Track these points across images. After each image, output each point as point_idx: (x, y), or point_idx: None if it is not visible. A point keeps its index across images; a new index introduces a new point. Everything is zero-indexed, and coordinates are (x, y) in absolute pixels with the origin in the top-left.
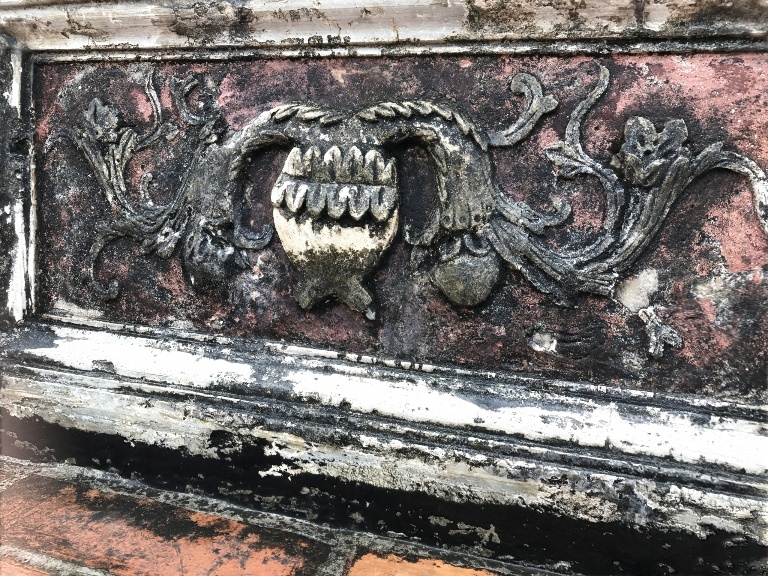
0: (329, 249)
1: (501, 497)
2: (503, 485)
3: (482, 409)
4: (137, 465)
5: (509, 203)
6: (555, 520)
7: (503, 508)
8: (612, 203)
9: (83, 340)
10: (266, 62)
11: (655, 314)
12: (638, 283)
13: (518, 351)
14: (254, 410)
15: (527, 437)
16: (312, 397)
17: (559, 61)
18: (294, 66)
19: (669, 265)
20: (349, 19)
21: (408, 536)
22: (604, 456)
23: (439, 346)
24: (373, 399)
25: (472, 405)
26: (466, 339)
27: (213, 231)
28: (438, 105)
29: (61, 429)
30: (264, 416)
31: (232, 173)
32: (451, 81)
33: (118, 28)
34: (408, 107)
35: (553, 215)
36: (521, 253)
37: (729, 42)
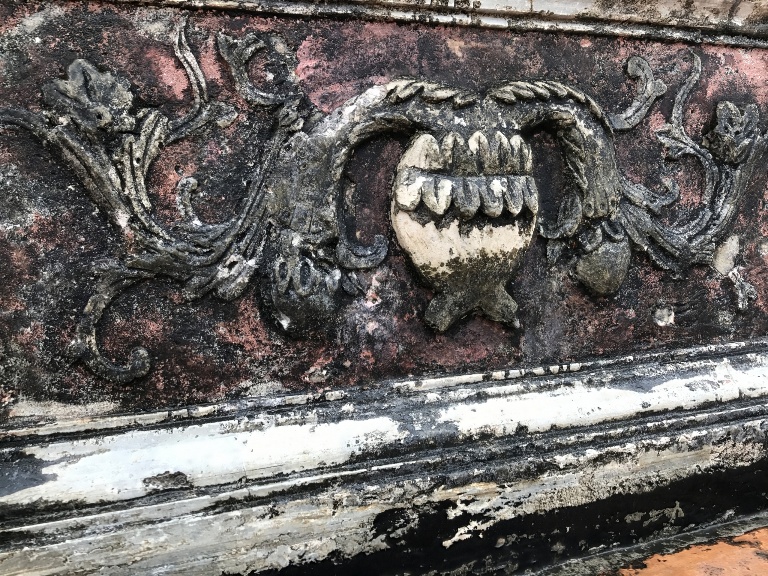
0: (479, 254)
1: (683, 472)
2: (684, 459)
3: (641, 393)
4: None
5: (631, 186)
6: (722, 476)
7: (685, 481)
8: (710, 180)
9: (101, 454)
10: (364, 24)
11: (739, 274)
12: (726, 249)
13: (647, 330)
14: (424, 470)
15: (685, 408)
16: (484, 432)
17: (662, 47)
18: (401, 32)
19: (745, 230)
20: None
21: (608, 545)
22: (743, 405)
23: (580, 341)
24: (547, 414)
25: (631, 392)
26: (603, 328)
27: (312, 251)
28: (568, 86)
29: None
30: (442, 472)
31: (337, 170)
32: (573, 61)
33: None
34: (544, 87)
35: (665, 195)
36: (647, 234)
37: None
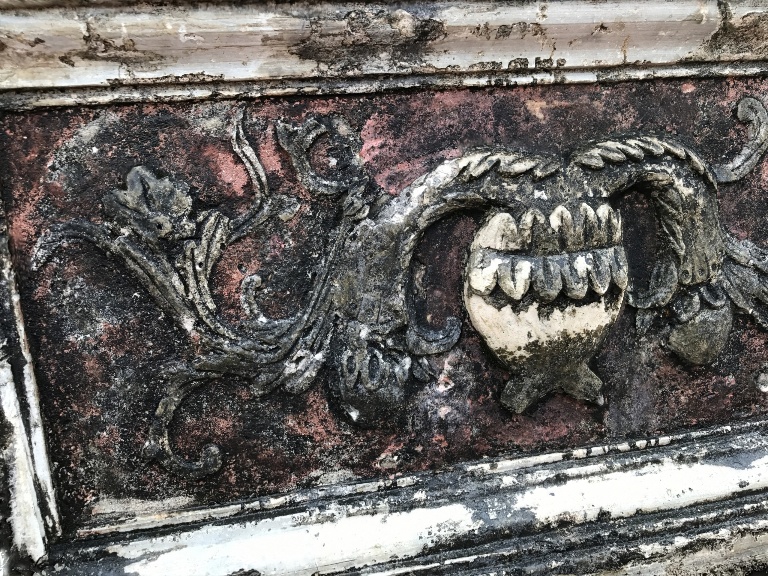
0: (560, 336)
1: None
2: None
3: (739, 470)
4: None
5: (736, 244)
6: None
7: None
8: None
9: (178, 550)
10: (433, 94)
11: None
12: None
13: (748, 397)
14: (499, 562)
15: None
16: (563, 520)
17: None
18: (474, 99)
19: None
20: (574, 37)
21: None
22: None
23: (671, 413)
24: (632, 498)
25: (727, 469)
26: (697, 398)
27: (381, 342)
28: (666, 141)
29: None
30: (518, 565)
31: (406, 258)
32: (672, 110)
33: (189, 49)
34: (637, 147)
35: None
36: (753, 296)
37: None
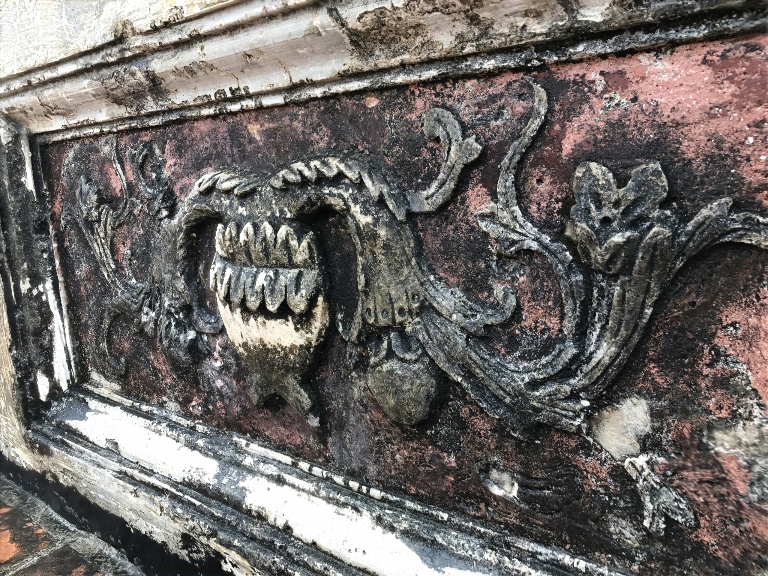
0: (260, 343)
1: None
2: None
3: (424, 565)
4: (137, 551)
5: (441, 290)
6: None
7: None
8: (568, 296)
9: (105, 414)
10: (193, 123)
11: (649, 468)
12: (620, 417)
13: (472, 490)
14: (212, 518)
15: None
16: (260, 512)
17: (479, 84)
18: (216, 125)
19: (664, 395)
20: (238, 67)
21: None
22: None
23: (386, 468)
24: (313, 527)
25: (414, 556)
26: (414, 464)
27: (176, 313)
28: (346, 162)
29: (88, 502)
30: (217, 527)
31: (179, 252)
32: (360, 127)
33: (76, 105)
34: (314, 168)
35: (496, 309)
36: (458, 361)
37: (730, 18)
